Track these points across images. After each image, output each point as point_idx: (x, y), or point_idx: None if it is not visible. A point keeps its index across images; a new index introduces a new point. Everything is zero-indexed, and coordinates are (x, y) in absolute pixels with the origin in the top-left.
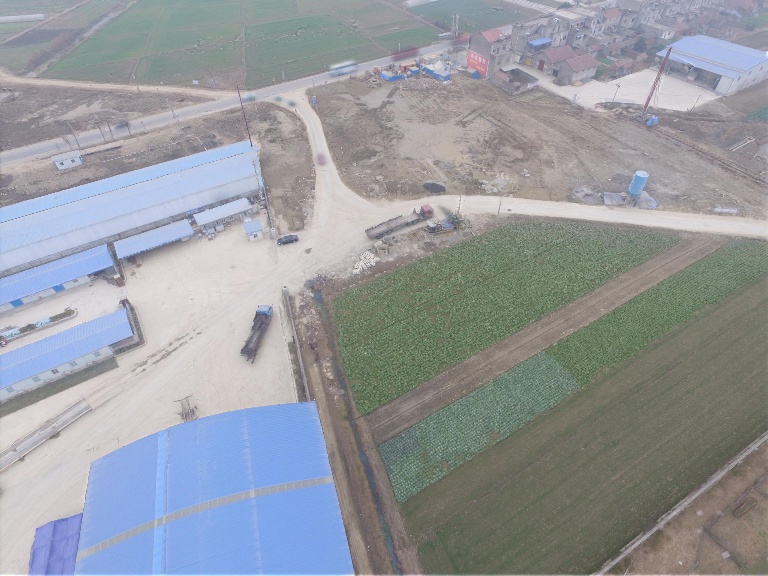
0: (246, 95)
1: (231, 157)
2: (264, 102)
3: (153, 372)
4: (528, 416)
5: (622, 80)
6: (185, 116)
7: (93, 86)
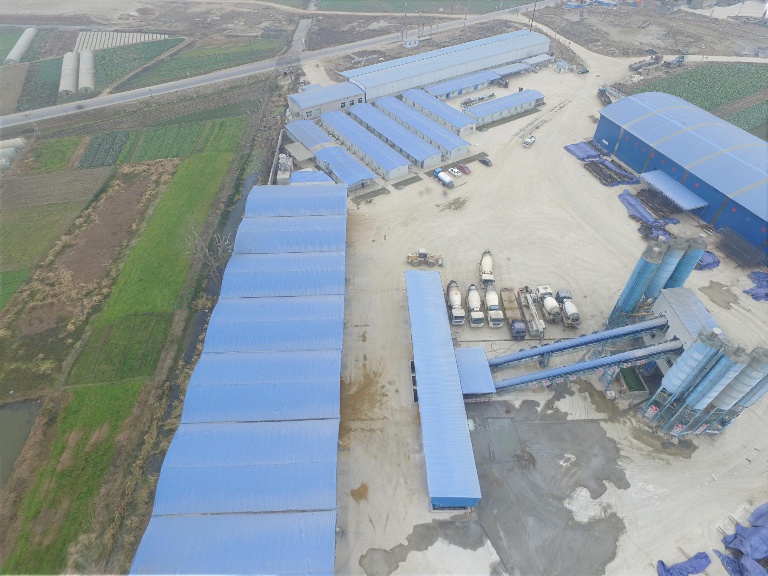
0: (482, 16)
1: (525, 35)
2: (499, 19)
3: (562, 112)
4: (766, 120)
5: (736, 6)
6: (454, 26)
7: (367, 14)
